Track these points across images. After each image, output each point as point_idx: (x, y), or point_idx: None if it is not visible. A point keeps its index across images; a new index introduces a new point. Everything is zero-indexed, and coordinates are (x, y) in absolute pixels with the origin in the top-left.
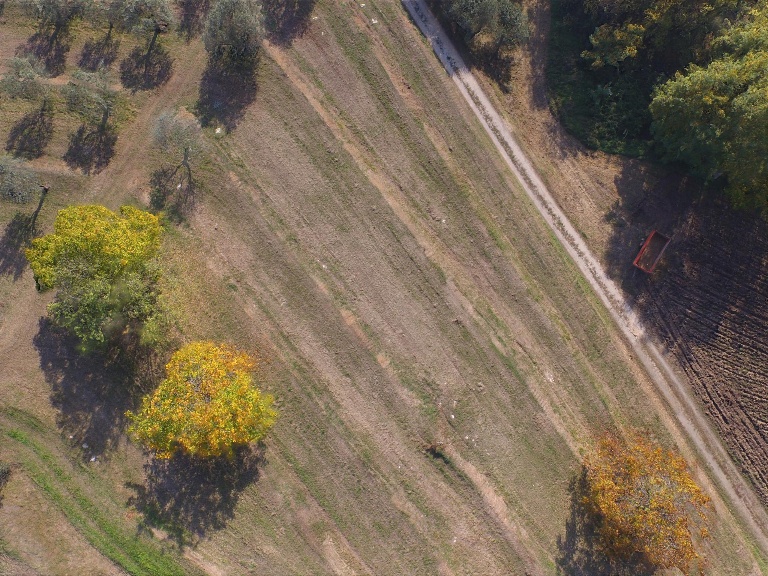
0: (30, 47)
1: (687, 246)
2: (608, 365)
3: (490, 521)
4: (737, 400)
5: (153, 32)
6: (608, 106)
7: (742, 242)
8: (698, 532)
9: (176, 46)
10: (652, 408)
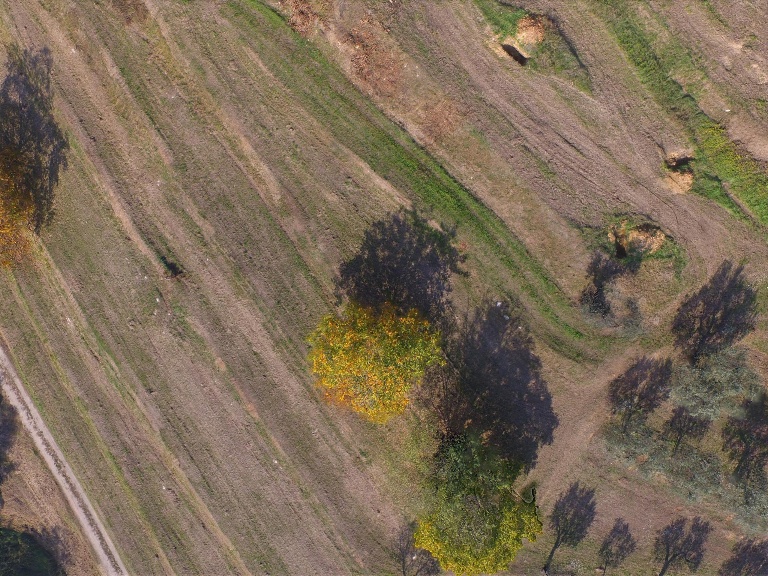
0: None
1: None
2: (17, 325)
3: (126, 195)
4: None
5: None
6: None
7: None
8: None
9: None
10: None
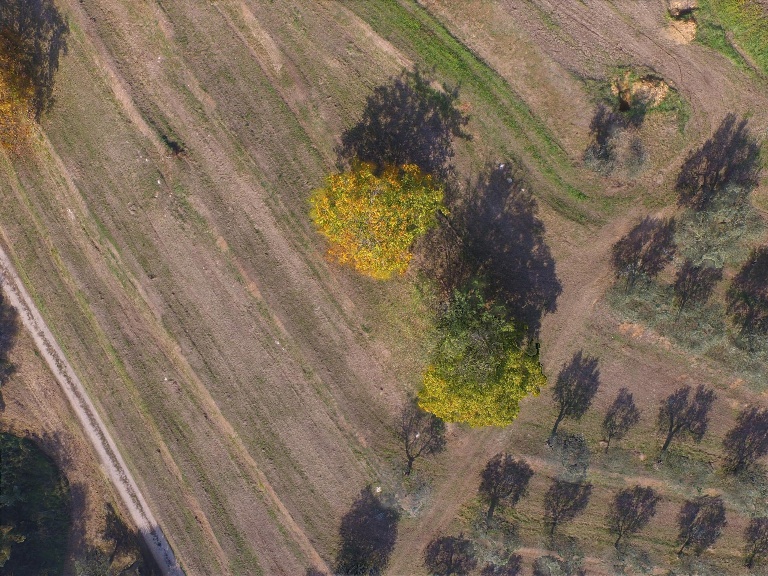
0: None
1: None
2: (18, 221)
3: (127, 76)
4: None
5: None
6: (6, 483)
7: None
8: None
9: None
10: None
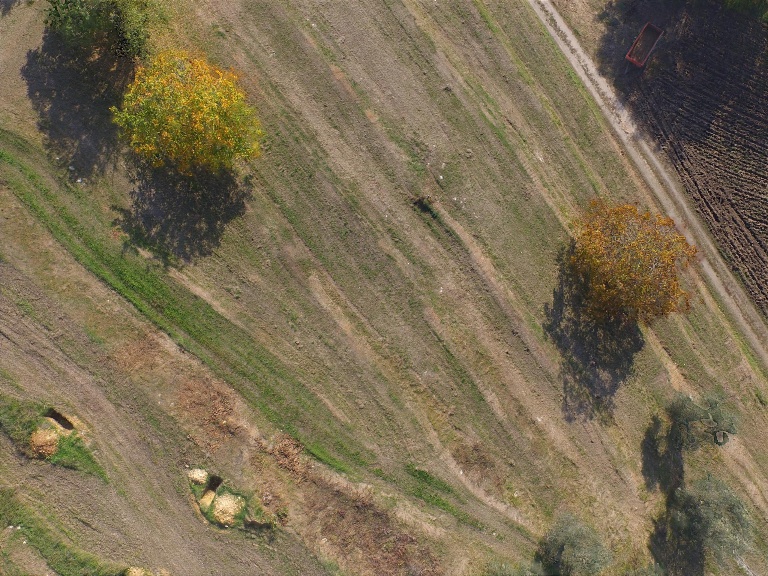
0: None
1: (680, 45)
2: (599, 155)
3: (477, 278)
4: (728, 198)
5: None
6: None
7: (736, 43)
8: (687, 323)
9: None
10: (642, 200)
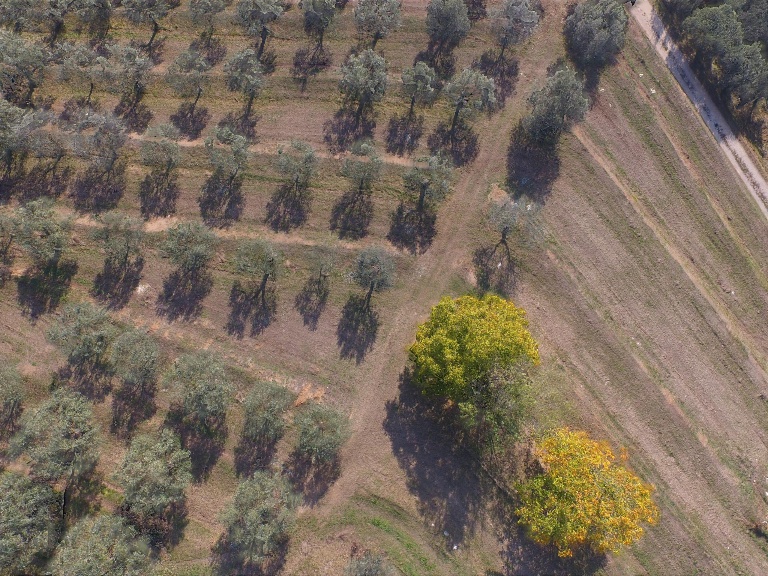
0: (337, 123)
1: None
2: None
3: None
4: None
5: (455, 107)
6: None
7: None
8: None
9: (478, 121)
10: None
